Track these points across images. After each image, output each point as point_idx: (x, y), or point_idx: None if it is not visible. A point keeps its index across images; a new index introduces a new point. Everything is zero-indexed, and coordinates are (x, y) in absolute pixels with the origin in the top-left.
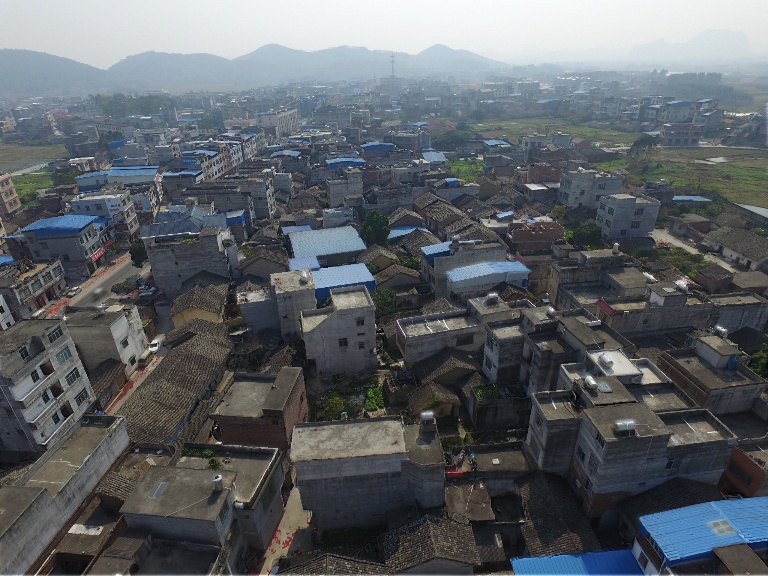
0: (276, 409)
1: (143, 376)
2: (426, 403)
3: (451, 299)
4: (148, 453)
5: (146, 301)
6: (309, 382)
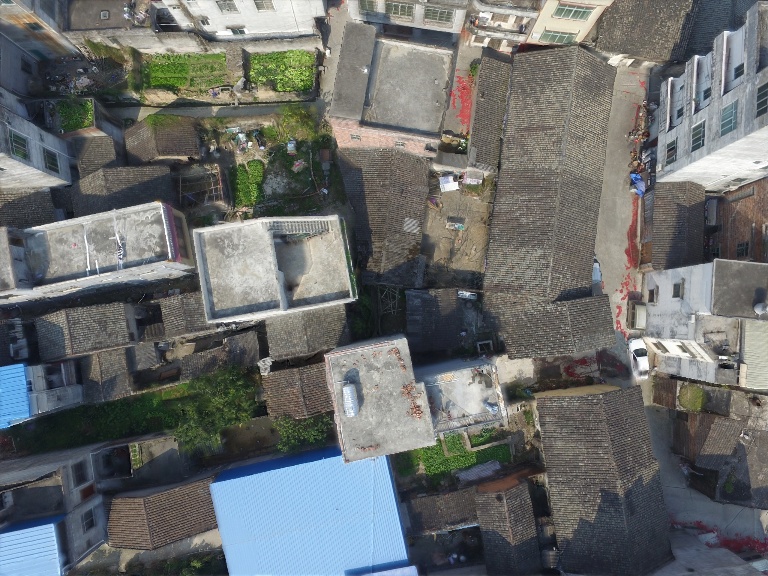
0: (355, 23)
1: (622, 277)
2: (169, 120)
3: (62, 386)
4: (513, 7)
5: (727, 492)
6: (348, 230)
